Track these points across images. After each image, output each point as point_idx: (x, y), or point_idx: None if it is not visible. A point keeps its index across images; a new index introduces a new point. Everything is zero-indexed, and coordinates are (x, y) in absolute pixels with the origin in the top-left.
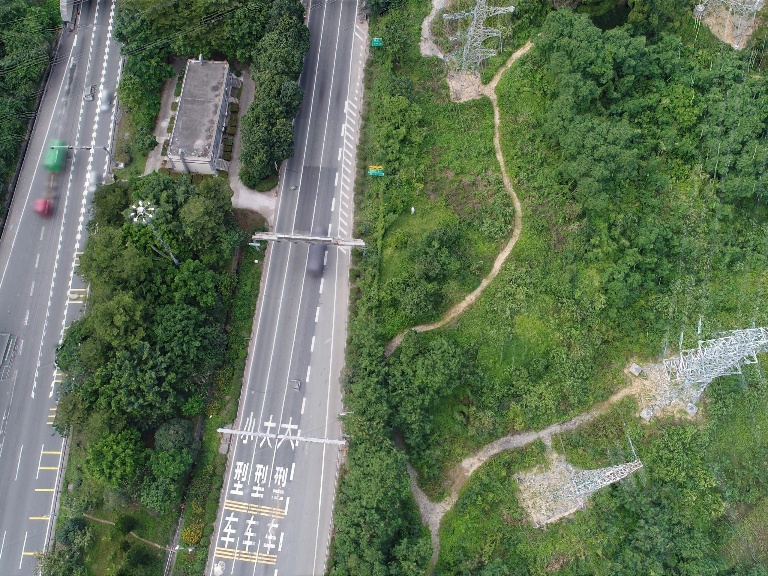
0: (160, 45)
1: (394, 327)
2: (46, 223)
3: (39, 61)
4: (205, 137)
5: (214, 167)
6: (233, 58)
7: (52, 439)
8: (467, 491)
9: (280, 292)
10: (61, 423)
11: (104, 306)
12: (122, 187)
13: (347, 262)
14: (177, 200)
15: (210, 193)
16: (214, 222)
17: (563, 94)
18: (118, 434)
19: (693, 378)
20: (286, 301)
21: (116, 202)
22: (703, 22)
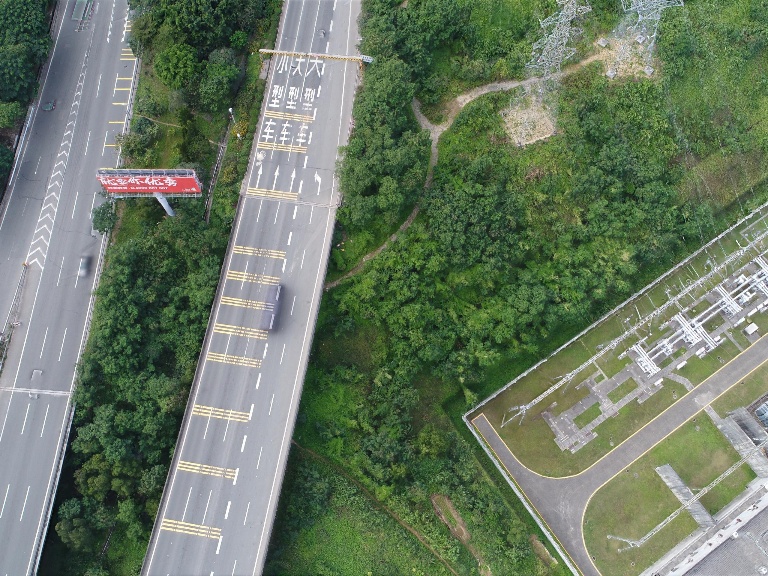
0: None
1: None
2: None
3: None
4: None
5: None
6: None
7: (125, 70)
8: (461, 112)
9: None
10: (135, 40)
11: None
12: None
13: None
14: None
15: None
16: None
17: None
18: (181, 45)
19: (644, 8)
20: None
21: None
22: None
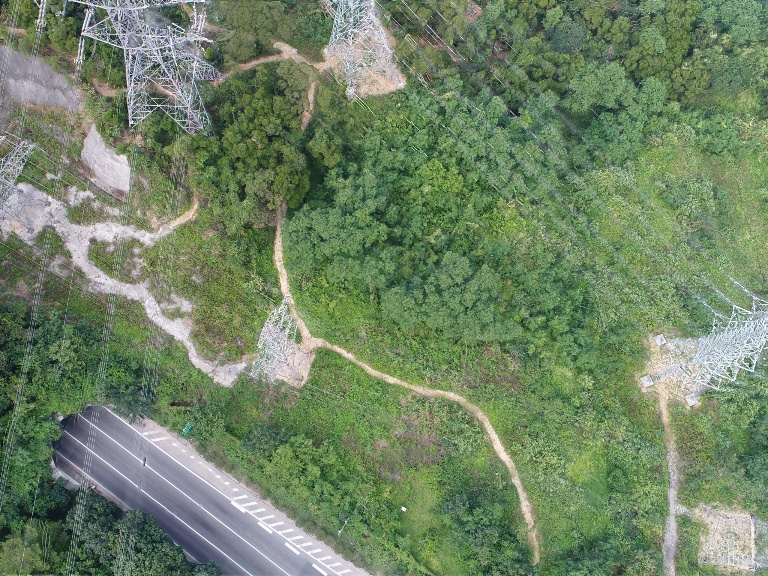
0: None
1: None
2: None
3: None
4: None
5: None
6: None
7: None
8: None
9: None
10: None
11: None
12: None
13: None
14: None
15: None
16: None
17: None
18: None
19: None
20: None
21: None
22: (362, 96)
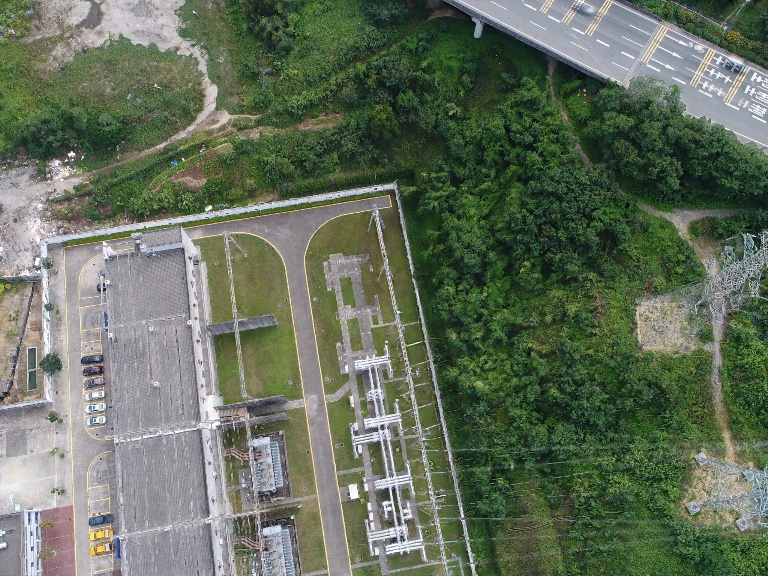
0: None
1: None
2: None
3: None
4: None
5: None
6: None
7: None
8: None
9: None
10: None
11: None
12: None
13: None
14: None
15: None
16: None
17: None
18: None
19: (767, 469)
20: None
21: None
22: None
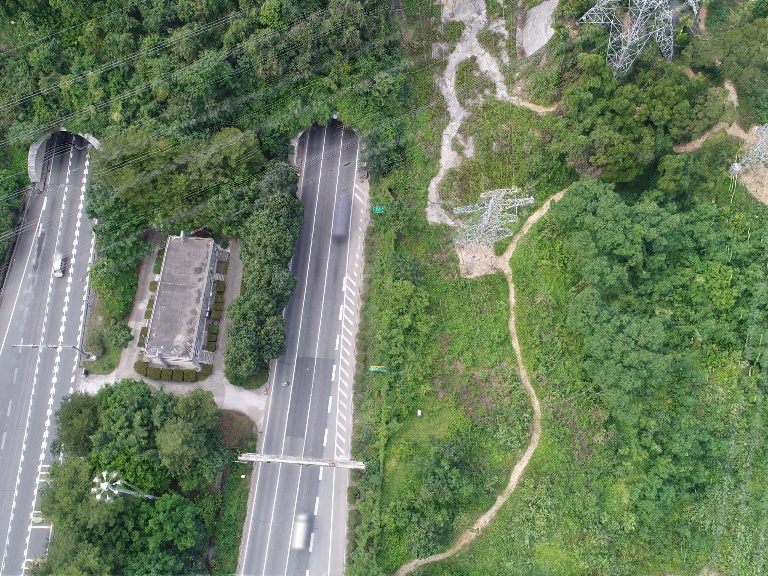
0: (137, 223)
1: (398, 557)
2: (8, 428)
3: (2, 239)
4: (186, 331)
5: (197, 361)
6: (219, 232)
7: None
8: None
9: (270, 514)
10: None
11: (65, 571)
12: (91, 404)
13: (345, 477)
14: (153, 421)
15: (190, 413)
16: (194, 449)
17: (587, 278)
18: None
19: None
20: (276, 525)
21: (83, 426)
22: (739, 181)
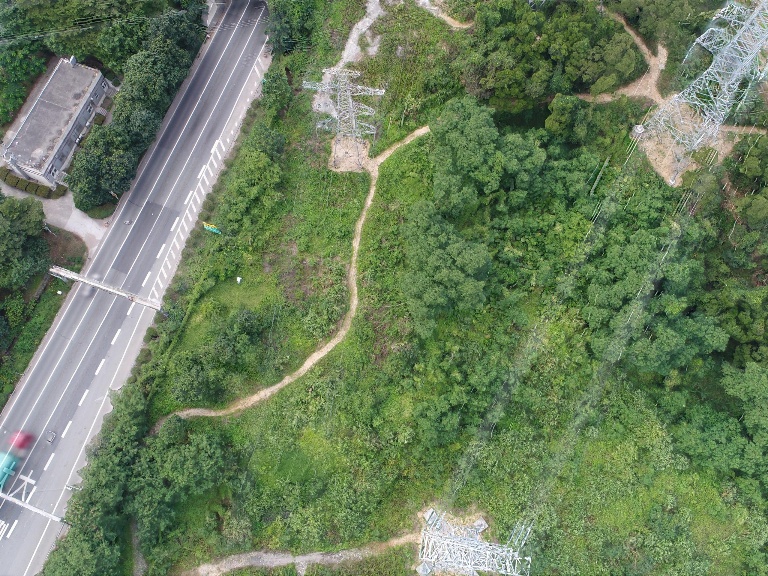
0: (32, 37)
1: (173, 403)
2: None
3: None
4: (47, 147)
5: (53, 180)
6: None
7: None
8: None
9: (72, 332)
10: None
11: None
12: None
13: (150, 318)
14: None
15: (13, 214)
16: (6, 246)
17: None
18: None
19: None
20: (74, 343)
21: None
22: (640, 145)
